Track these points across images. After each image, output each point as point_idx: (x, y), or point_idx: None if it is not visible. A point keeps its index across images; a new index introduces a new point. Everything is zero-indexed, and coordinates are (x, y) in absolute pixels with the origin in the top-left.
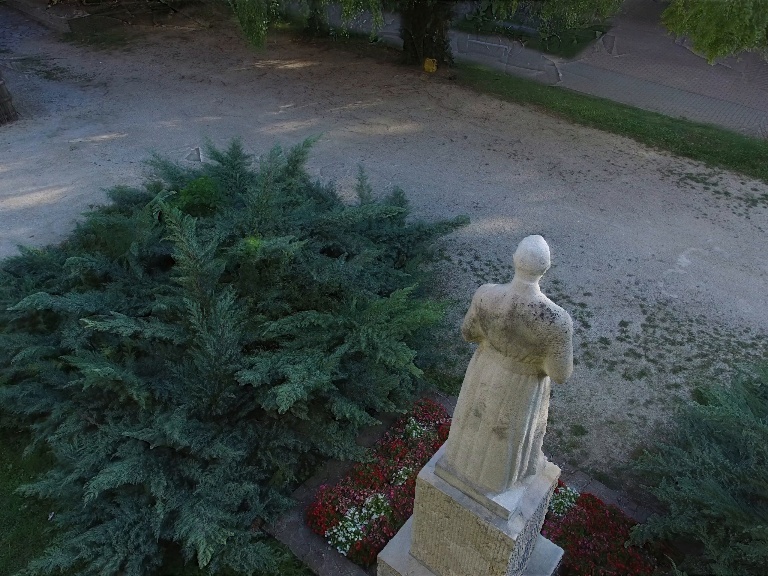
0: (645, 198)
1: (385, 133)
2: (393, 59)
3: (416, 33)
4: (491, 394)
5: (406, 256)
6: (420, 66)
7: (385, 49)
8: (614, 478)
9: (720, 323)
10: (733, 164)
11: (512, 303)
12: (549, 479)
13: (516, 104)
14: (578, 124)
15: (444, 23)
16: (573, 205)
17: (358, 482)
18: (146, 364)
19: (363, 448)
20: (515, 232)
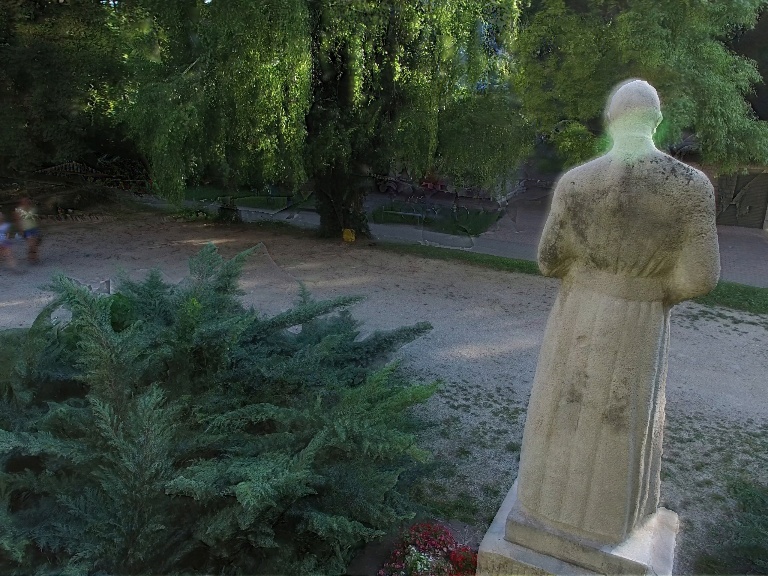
0: None
1: (313, 287)
2: (310, 234)
3: (335, 198)
4: (596, 349)
5: None
6: (338, 238)
7: (300, 231)
8: None
9: (720, 417)
10: None
11: (626, 165)
12: (669, 528)
13: (440, 260)
14: (504, 271)
15: (359, 197)
16: (524, 330)
17: None
18: (26, 514)
19: None
20: (473, 356)
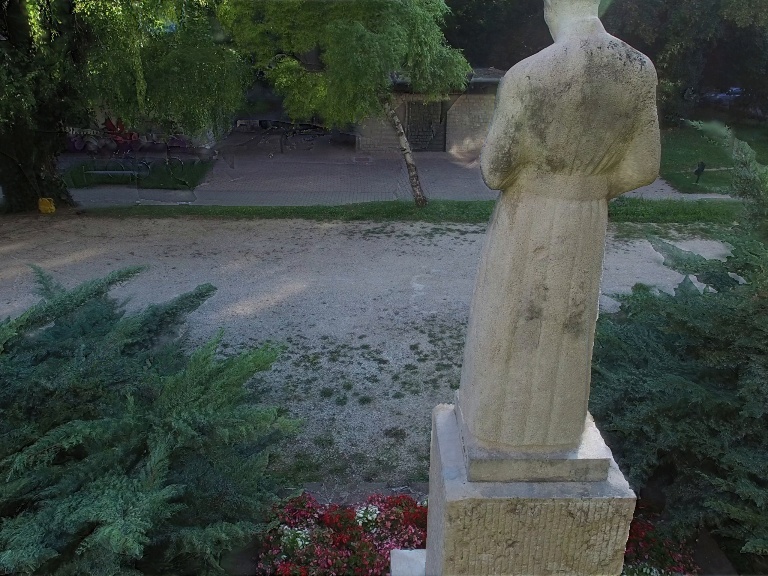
0: (347, 254)
1: None
2: None
3: (23, 161)
4: (556, 258)
5: None
6: (32, 211)
7: None
8: None
9: None
10: (394, 216)
11: (585, 52)
12: None
13: (168, 218)
14: (243, 219)
15: (49, 158)
16: (289, 275)
17: None
18: None
19: None
20: (250, 312)
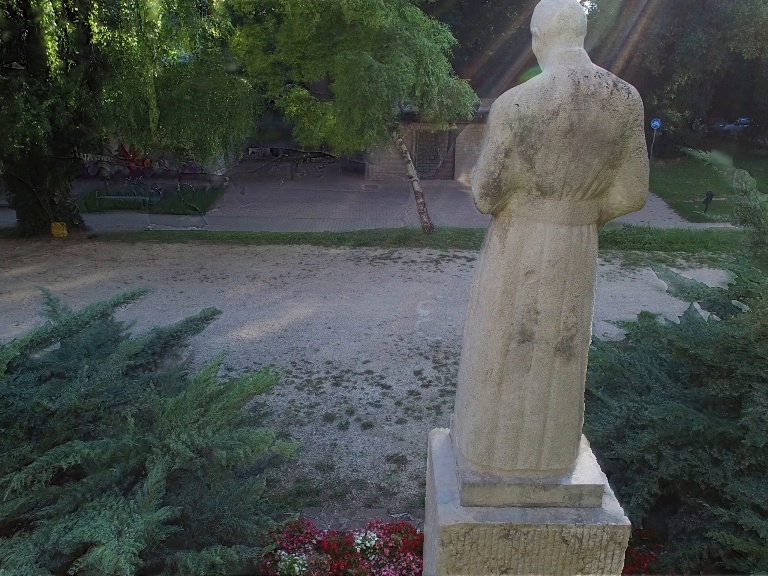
0: (354, 280)
1: None
2: (5, 235)
3: (37, 186)
4: (547, 282)
5: None
6: (45, 235)
7: None
8: None
9: None
10: (401, 242)
11: (573, 81)
12: None
13: (178, 243)
14: (252, 245)
15: (63, 183)
16: (295, 300)
17: None
18: None
19: None
20: (255, 336)
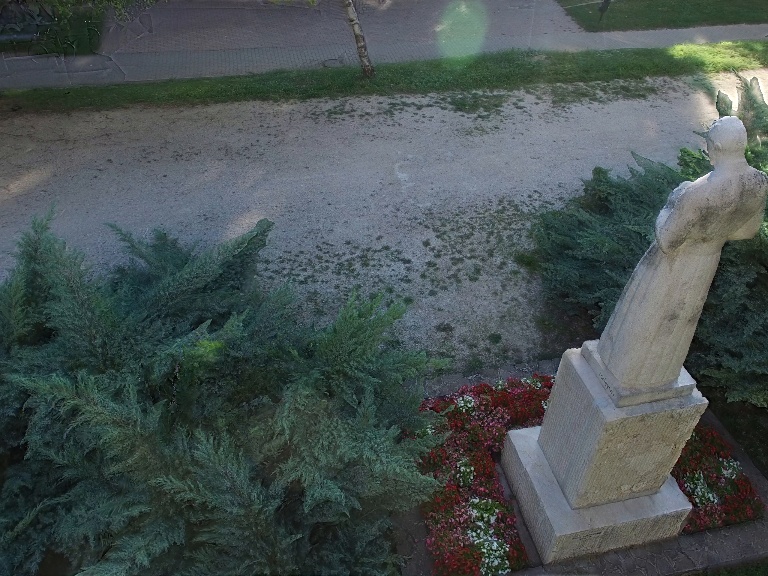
0: (323, 143)
1: (11, 196)
2: None
3: None
4: (695, 288)
5: (241, 291)
6: None
7: None
8: (549, 351)
9: (473, 206)
10: (348, 90)
11: (742, 184)
12: None
13: (119, 109)
14: (199, 105)
15: None
16: (282, 175)
17: (444, 509)
18: None
19: (429, 475)
20: None
